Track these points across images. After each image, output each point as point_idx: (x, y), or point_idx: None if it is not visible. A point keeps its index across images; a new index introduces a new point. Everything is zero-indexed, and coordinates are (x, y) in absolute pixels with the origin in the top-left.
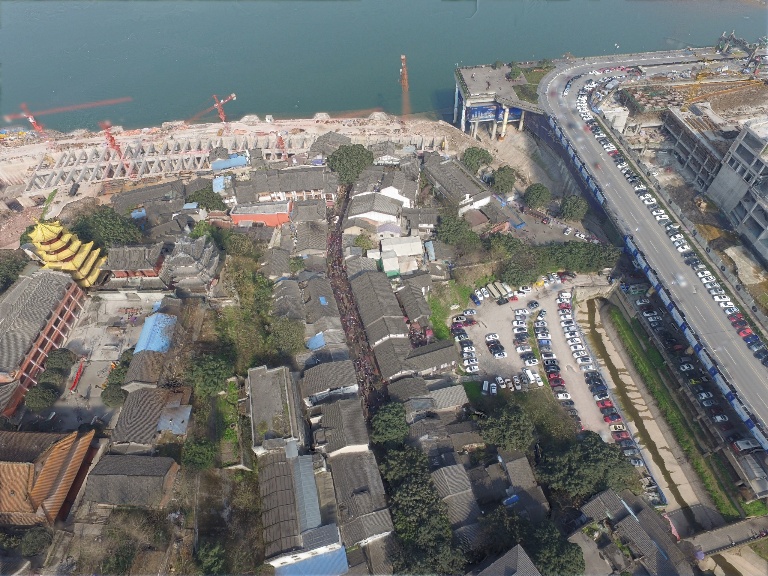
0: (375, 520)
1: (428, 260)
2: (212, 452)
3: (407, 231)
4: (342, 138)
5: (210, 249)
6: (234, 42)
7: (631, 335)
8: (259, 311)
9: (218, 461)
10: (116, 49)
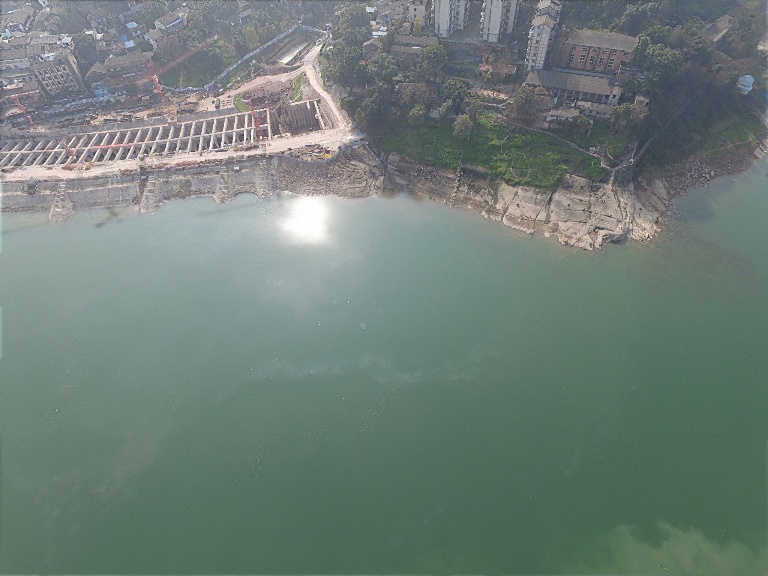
0: None
1: None
2: None
3: None
4: None
5: None
6: (17, 429)
7: None
8: None
9: None
10: (283, 406)
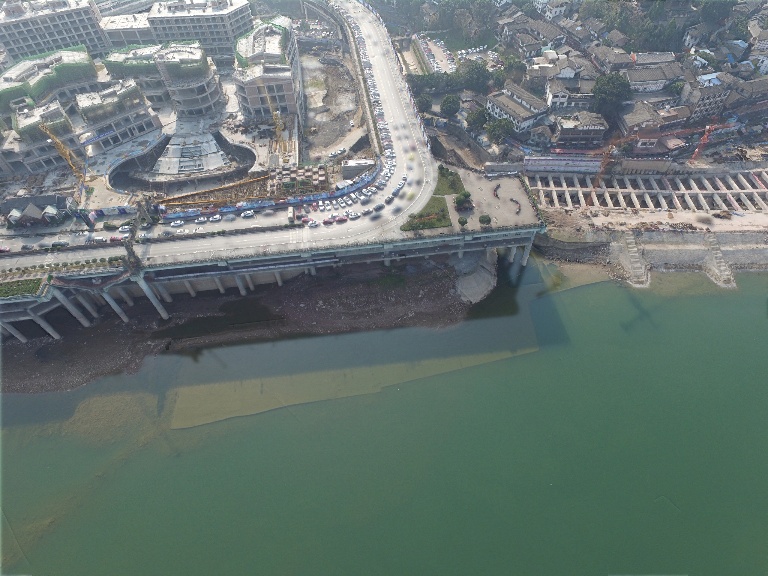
0: None
1: None
2: None
3: None
4: (637, 120)
5: None
6: None
7: None
8: None
9: None
10: None
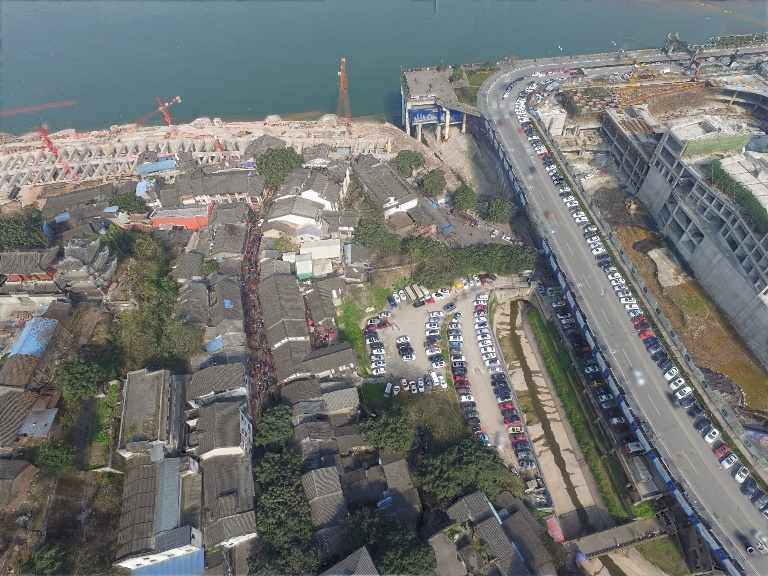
0: (238, 522)
1: (344, 263)
2: (68, 455)
3: (329, 234)
4: (276, 141)
5: (105, 253)
6: (196, 45)
7: (546, 337)
8: (160, 314)
9: (85, 464)
10: (79, 52)
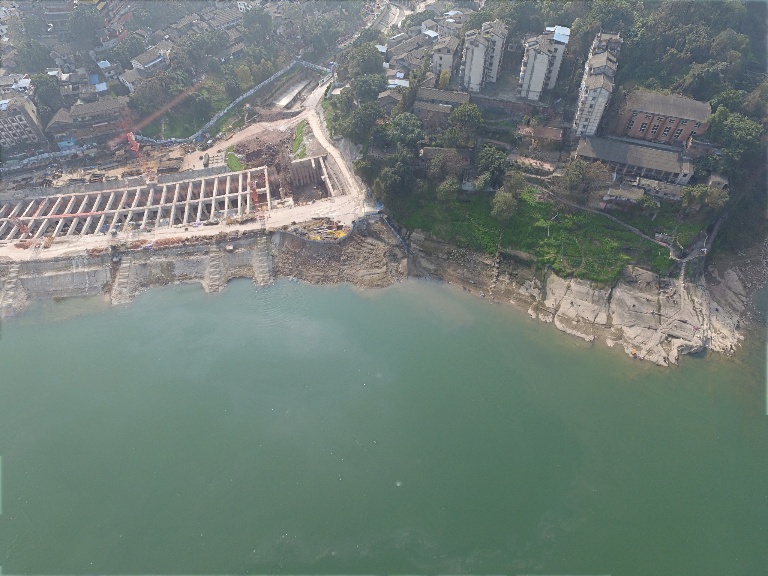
0: None
1: None
2: None
3: None
4: None
5: None
6: None
7: None
8: None
9: None
10: None
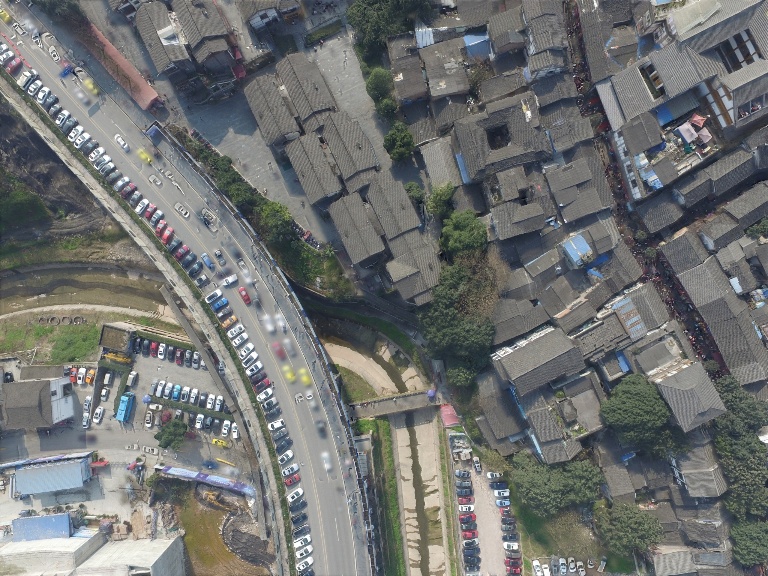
0: None
1: None
2: None
3: None
4: None
5: None
6: None
7: None
8: None
9: None
10: None
